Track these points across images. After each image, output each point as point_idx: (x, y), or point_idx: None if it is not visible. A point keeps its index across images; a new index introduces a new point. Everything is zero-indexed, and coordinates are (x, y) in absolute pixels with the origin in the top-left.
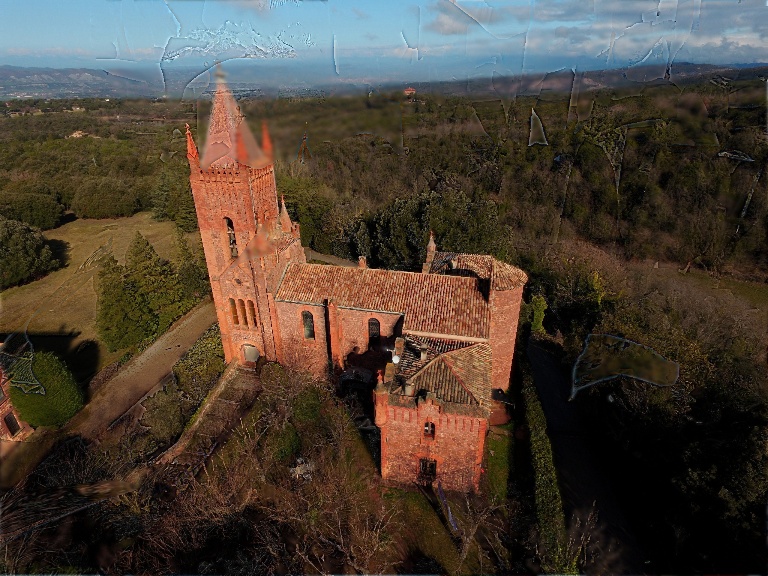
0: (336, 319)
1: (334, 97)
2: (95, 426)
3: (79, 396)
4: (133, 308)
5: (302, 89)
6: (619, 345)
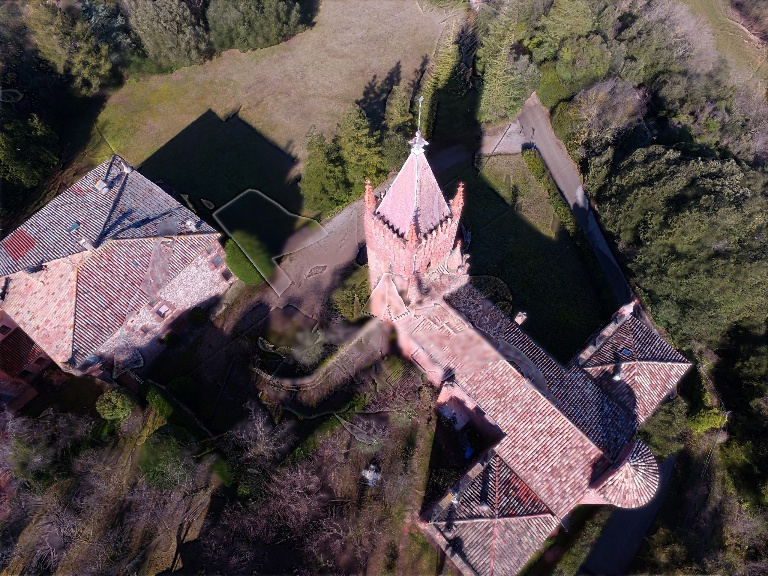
0: None
1: None
2: (277, 296)
3: None
4: (331, 183)
5: None
6: None
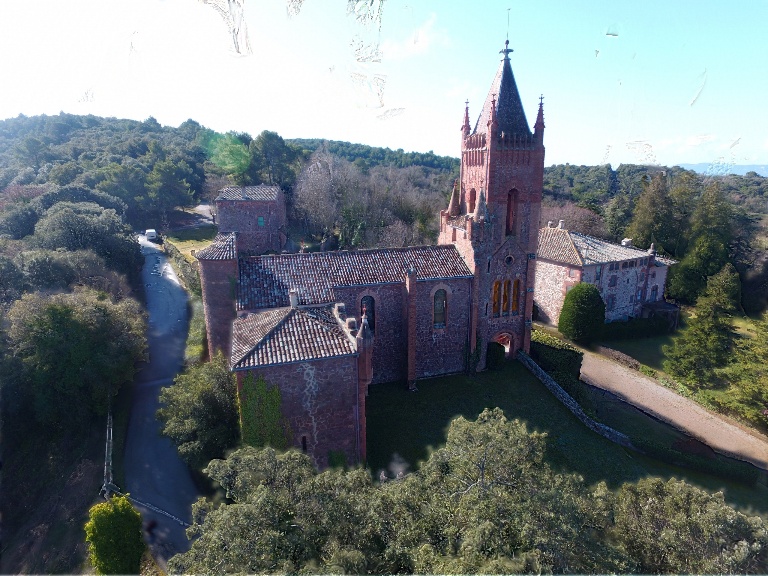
0: None
1: None
2: None
3: (574, 330)
4: None
5: (359, 74)
6: (201, 152)
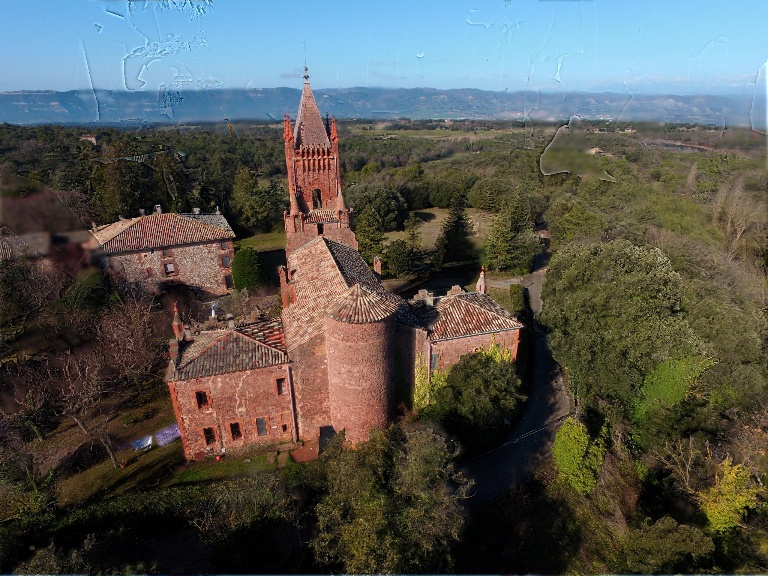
0: (282, 285)
1: (235, 87)
2: None
3: (260, 286)
4: None
5: (210, 80)
6: None
